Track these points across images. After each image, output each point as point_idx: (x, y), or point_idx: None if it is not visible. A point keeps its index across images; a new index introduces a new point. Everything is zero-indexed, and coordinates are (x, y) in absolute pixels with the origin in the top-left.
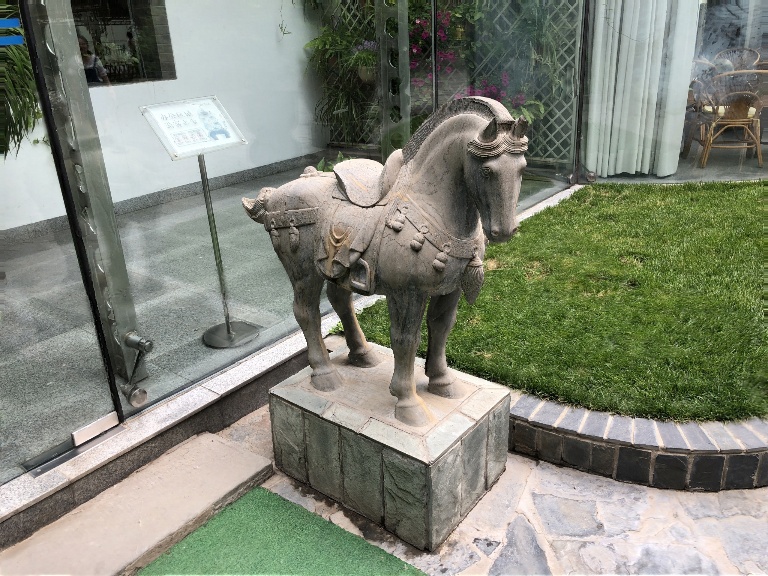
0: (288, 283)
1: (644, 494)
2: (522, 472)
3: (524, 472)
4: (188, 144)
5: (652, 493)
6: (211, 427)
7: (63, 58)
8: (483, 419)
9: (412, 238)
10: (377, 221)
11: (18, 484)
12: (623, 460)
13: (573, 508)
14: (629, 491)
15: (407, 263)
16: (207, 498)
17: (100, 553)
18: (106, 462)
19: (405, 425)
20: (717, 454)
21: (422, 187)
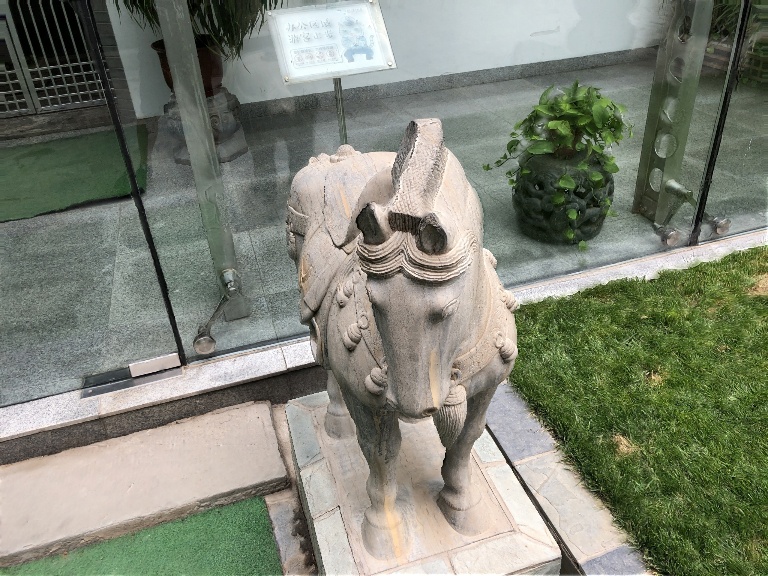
0: None
1: None
2: None
3: None
4: (310, 65)
5: None
6: (274, 397)
7: None
8: None
9: None
10: (332, 275)
11: (66, 399)
12: None
13: None
14: None
15: (340, 360)
16: (197, 490)
17: (79, 505)
18: (140, 407)
19: (361, 544)
20: None
21: None
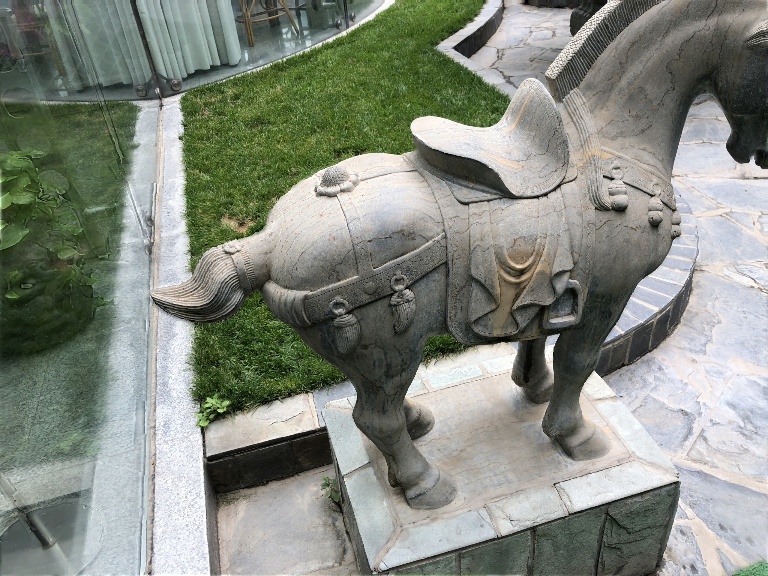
0: None
1: (658, 360)
2: None
3: None
4: None
5: (659, 355)
6: None
7: None
8: None
9: (647, 210)
10: (580, 209)
11: None
12: (635, 343)
13: (650, 414)
14: (648, 366)
15: (646, 250)
16: None
17: None
18: None
19: (599, 460)
20: (682, 290)
21: (624, 127)
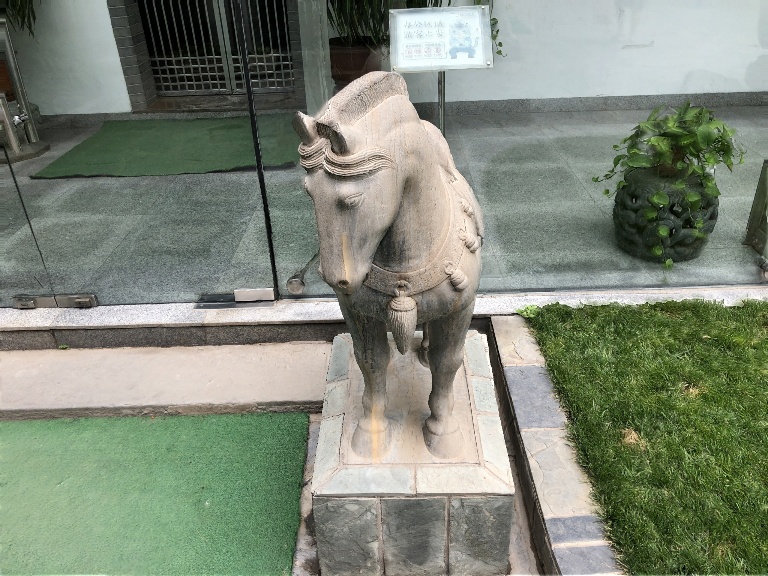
0: (570, 240)
1: None
2: None
3: None
4: (417, 58)
5: None
6: None
7: None
8: (434, 497)
9: None
10: None
11: (183, 307)
12: None
13: None
14: None
15: None
16: (258, 395)
17: (171, 385)
18: (234, 324)
19: (349, 442)
20: None
21: None
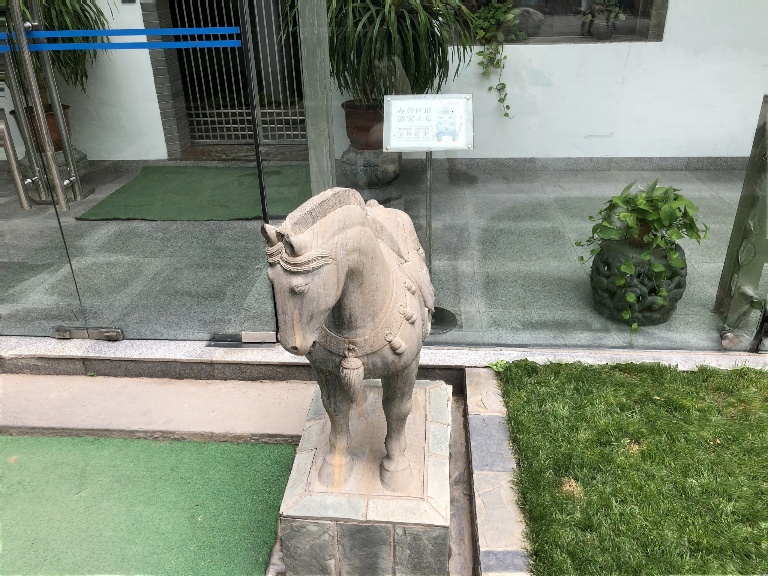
0: (551, 299)
1: None
2: None
3: None
4: (408, 140)
5: None
6: None
7: (305, 54)
8: (381, 524)
9: None
10: None
11: (196, 345)
12: None
13: None
14: None
15: None
16: (253, 427)
17: (179, 414)
18: (239, 362)
19: (317, 473)
20: None
21: None
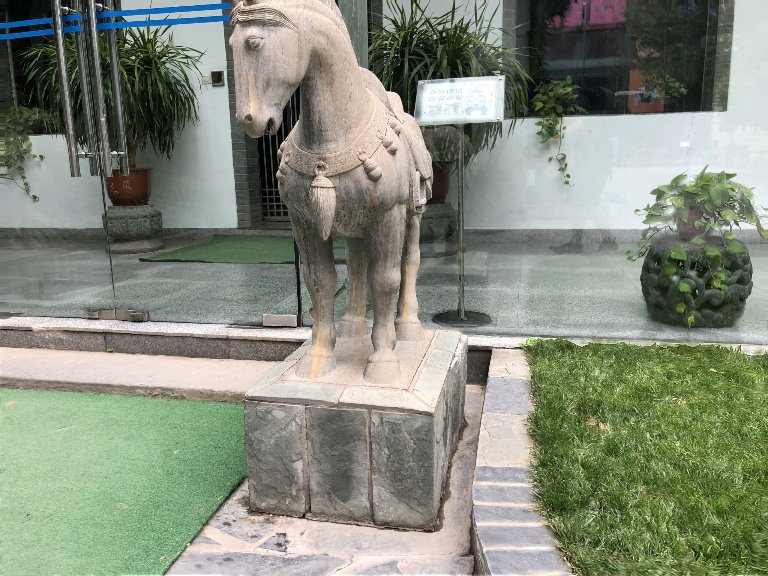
0: (599, 312)
1: None
2: (437, 547)
3: (438, 548)
4: (437, 116)
5: None
6: None
7: None
8: (354, 409)
9: None
10: None
11: (217, 326)
12: None
13: None
14: None
15: None
16: None
17: (184, 377)
18: (255, 338)
19: (295, 370)
20: None
21: None
